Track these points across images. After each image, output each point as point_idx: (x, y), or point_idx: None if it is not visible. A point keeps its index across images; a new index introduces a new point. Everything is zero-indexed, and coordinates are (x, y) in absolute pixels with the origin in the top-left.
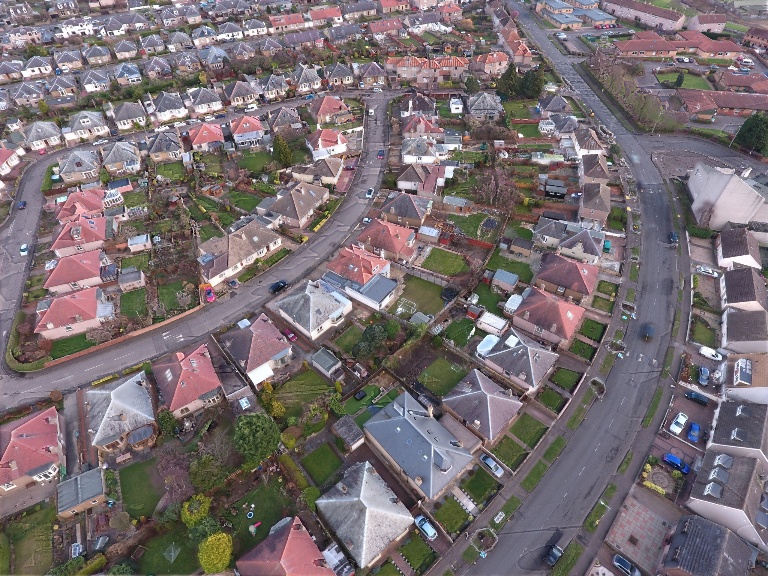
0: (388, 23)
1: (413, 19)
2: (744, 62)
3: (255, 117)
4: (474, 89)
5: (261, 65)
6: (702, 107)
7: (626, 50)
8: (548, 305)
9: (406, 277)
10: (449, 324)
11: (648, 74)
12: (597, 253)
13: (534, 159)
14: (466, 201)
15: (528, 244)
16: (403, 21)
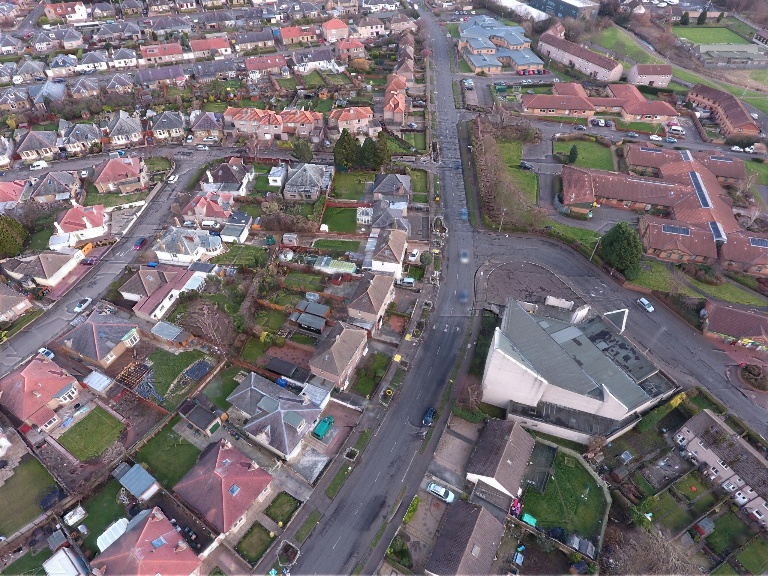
0: (268, 59)
1: (301, 55)
2: (672, 130)
3: (19, 182)
4: (303, 156)
5: (89, 108)
6: (577, 198)
7: (531, 107)
8: (128, 562)
9: (26, 457)
10: (17, 558)
11: (545, 141)
12: (285, 449)
13: (316, 267)
14: (180, 333)
15: (208, 419)
16: (292, 57)
